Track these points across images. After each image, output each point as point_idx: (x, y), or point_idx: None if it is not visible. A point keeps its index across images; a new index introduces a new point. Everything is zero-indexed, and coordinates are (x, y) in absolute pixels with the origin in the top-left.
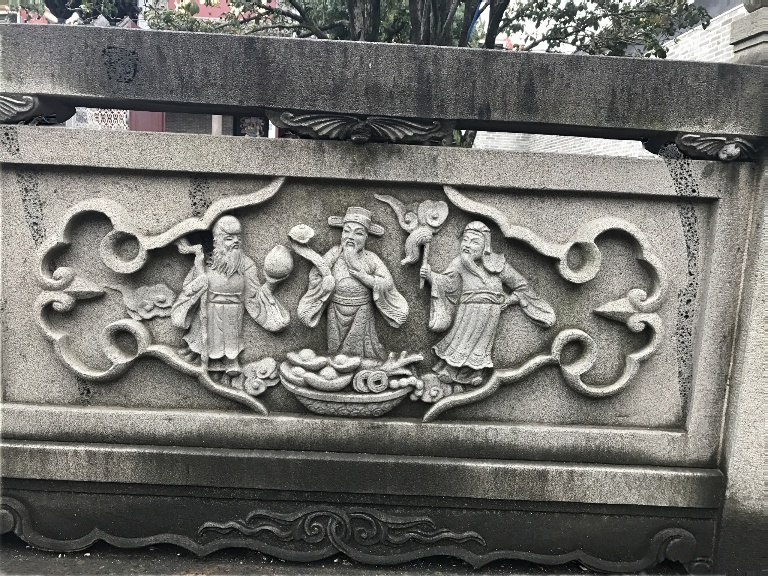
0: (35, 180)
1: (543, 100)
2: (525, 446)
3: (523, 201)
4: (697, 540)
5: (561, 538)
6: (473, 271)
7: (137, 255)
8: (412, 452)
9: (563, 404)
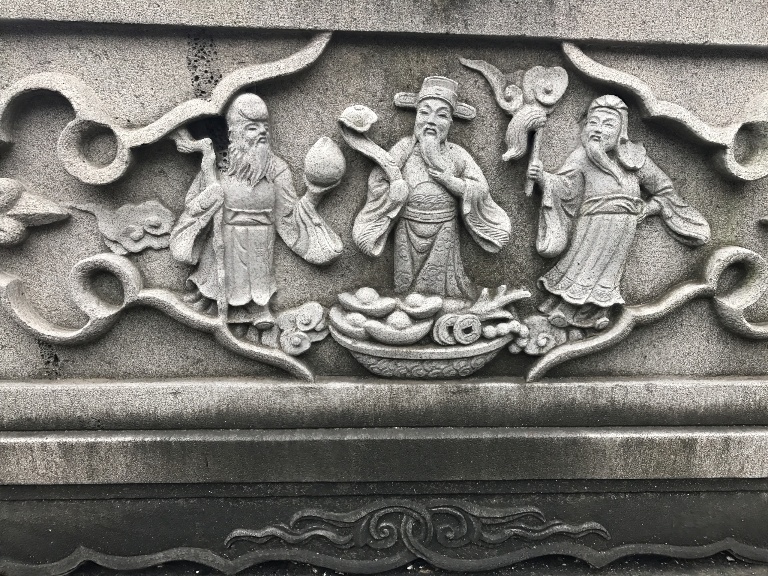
0: None
1: None
2: (663, 407)
3: (671, 65)
4: None
5: (708, 524)
6: (604, 167)
7: (115, 157)
8: (512, 422)
9: (712, 349)
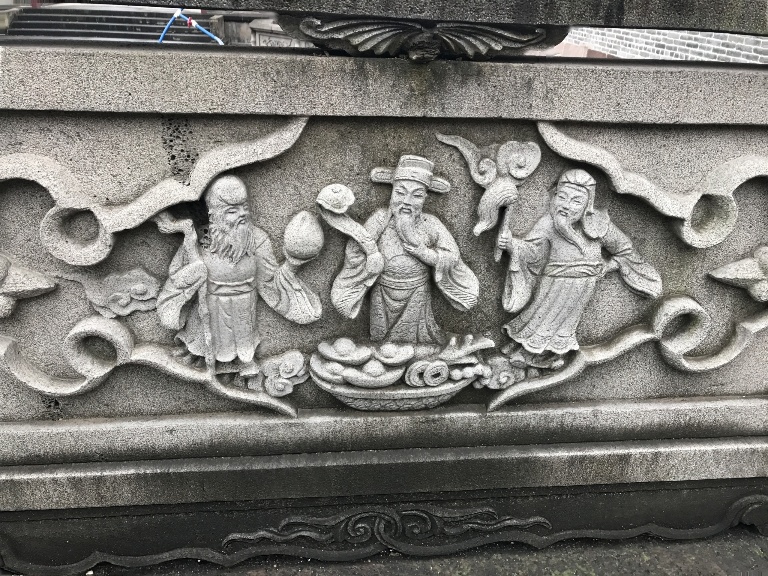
0: None
1: None
2: (605, 428)
3: (641, 137)
4: None
5: (635, 515)
6: (569, 239)
7: (97, 237)
8: (473, 443)
9: (653, 379)
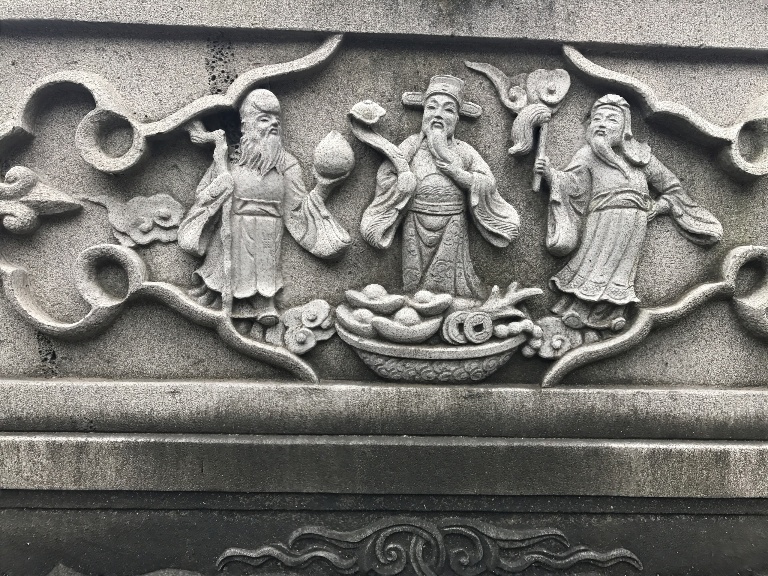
0: None
1: None
2: (689, 418)
3: (669, 69)
4: None
5: (751, 554)
6: (611, 161)
7: (130, 147)
8: (529, 432)
9: (736, 357)
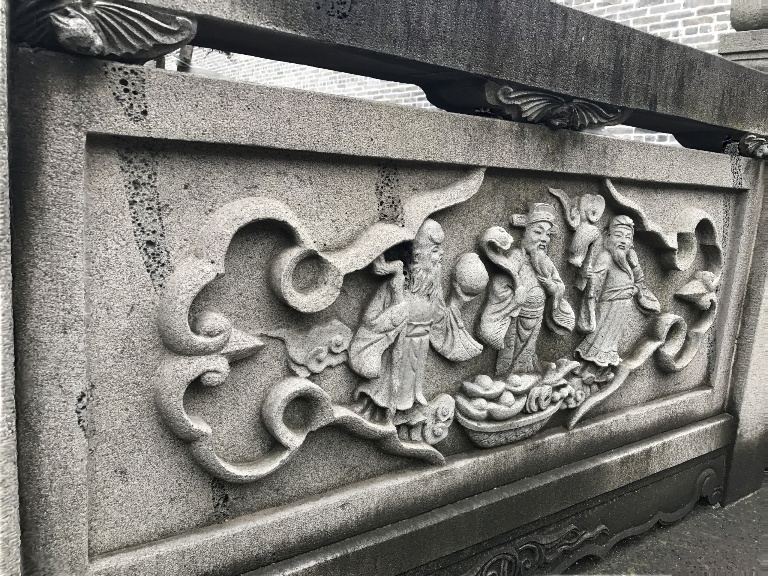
0: (152, 167)
1: (687, 95)
2: (632, 430)
3: (646, 193)
4: (716, 474)
5: (653, 505)
6: (624, 267)
7: (321, 282)
8: (561, 463)
9: (650, 384)
